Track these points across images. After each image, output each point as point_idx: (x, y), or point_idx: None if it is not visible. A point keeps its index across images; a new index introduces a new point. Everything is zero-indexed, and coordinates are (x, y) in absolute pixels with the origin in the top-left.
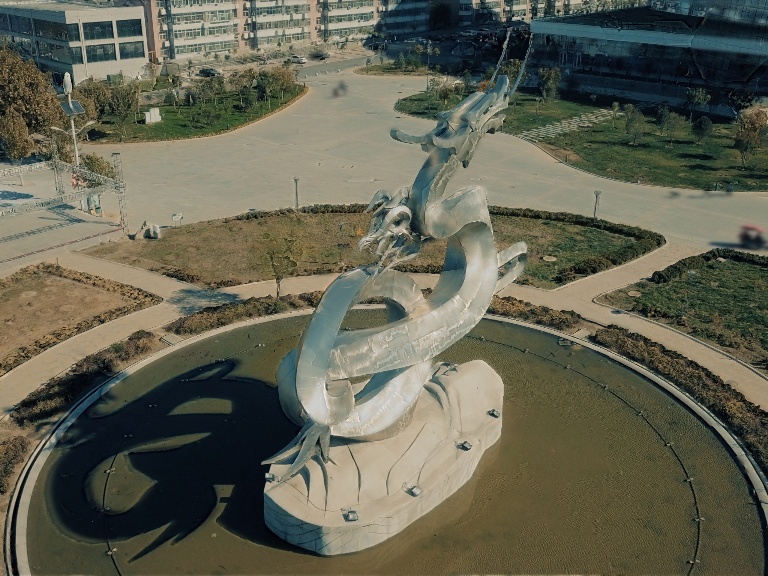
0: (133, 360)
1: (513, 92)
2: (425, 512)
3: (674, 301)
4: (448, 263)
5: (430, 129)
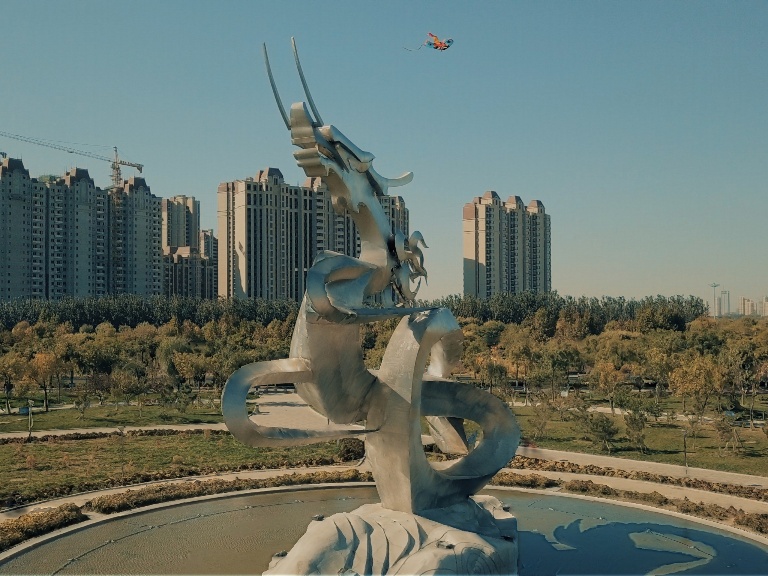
0: None
1: (287, 124)
2: None
3: None
4: None
5: None
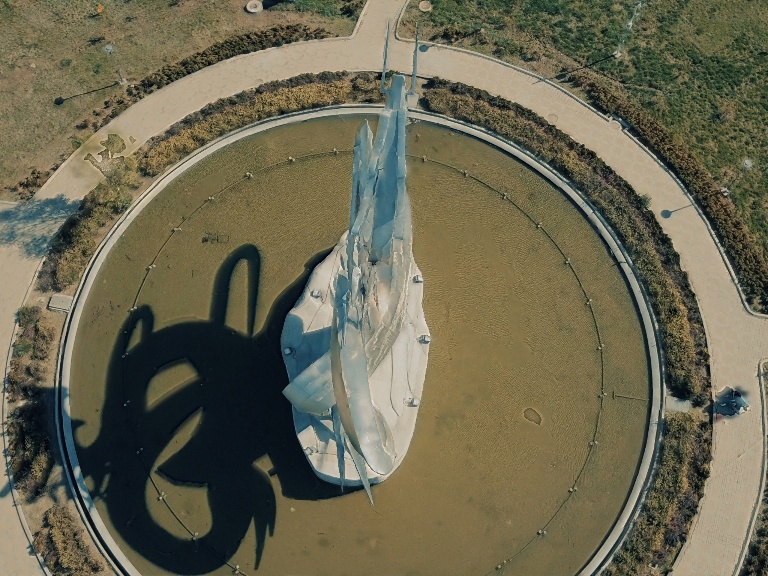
0: (51, 353)
1: None
2: (420, 402)
3: (463, 4)
4: None
5: None
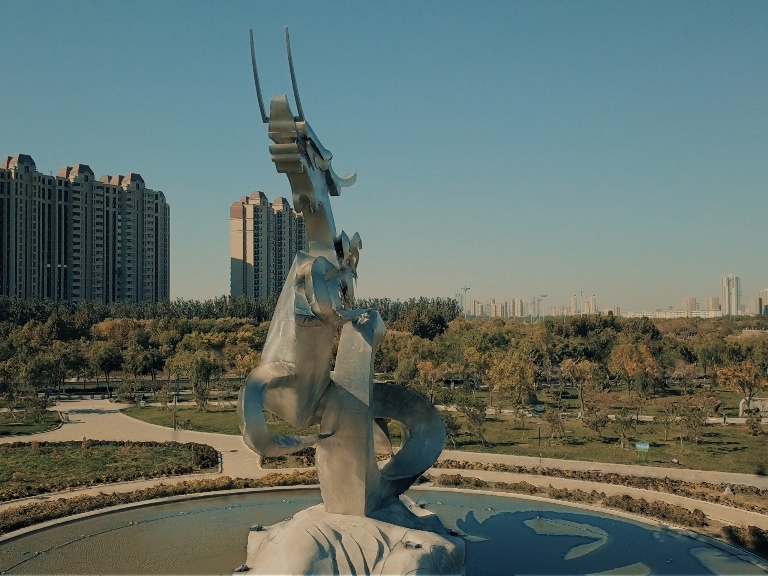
0: None
1: (263, 116)
2: None
3: None
4: None
5: None
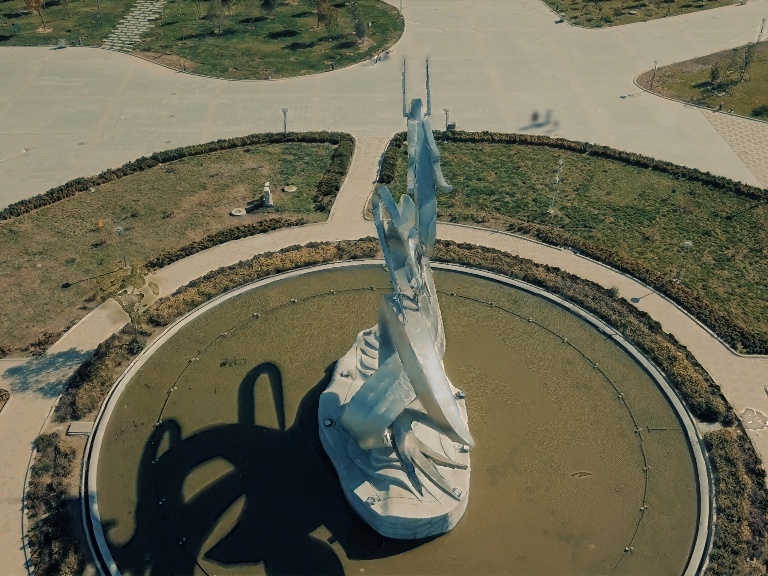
0: (74, 470)
1: None
2: None
3: None
4: (396, 262)
5: (0, 61)
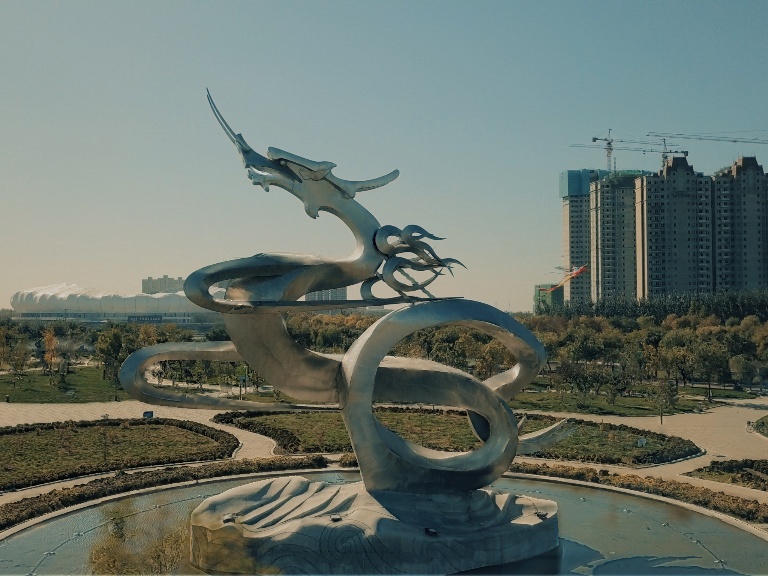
0: None
1: None
2: None
3: None
4: None
5: None
